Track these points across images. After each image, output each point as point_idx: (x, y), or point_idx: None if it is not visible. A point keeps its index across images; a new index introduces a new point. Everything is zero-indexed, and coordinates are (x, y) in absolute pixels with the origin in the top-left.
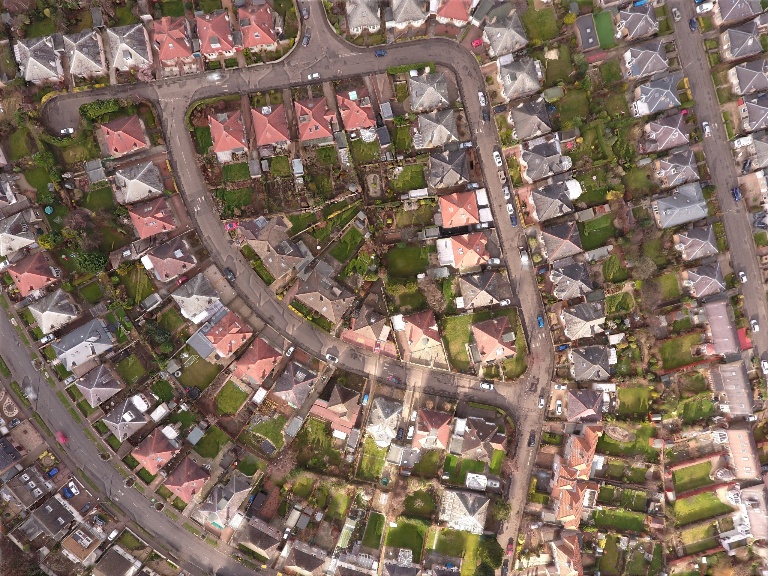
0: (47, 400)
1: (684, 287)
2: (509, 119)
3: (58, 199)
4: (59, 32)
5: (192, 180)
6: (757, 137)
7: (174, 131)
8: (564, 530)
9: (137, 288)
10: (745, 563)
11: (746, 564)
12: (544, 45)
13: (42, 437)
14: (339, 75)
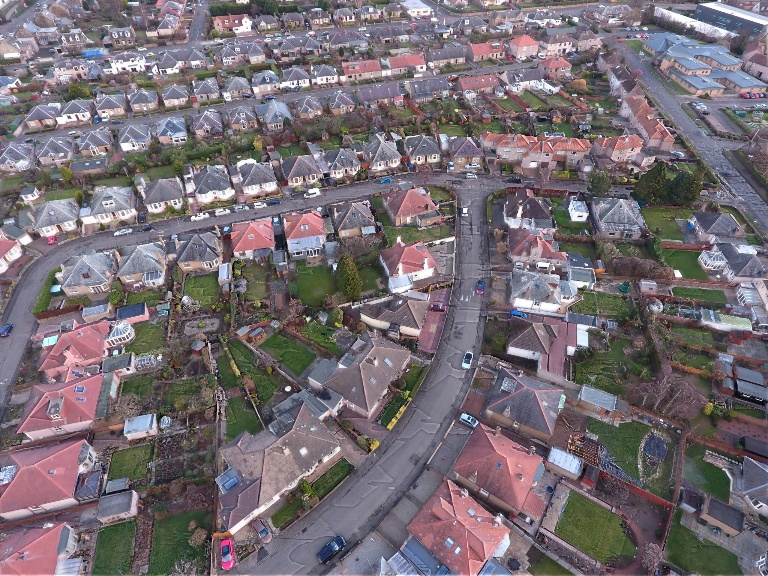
0: None
1: (347, 115)
2: (156, 210)
3: None
4: None
5: None
6: (225, 90)
7: None
8: (595, 155)
9: None
10: (565, 82)
11: (566, 82)
12: (85, 193)
13: None
14: (9, 383)
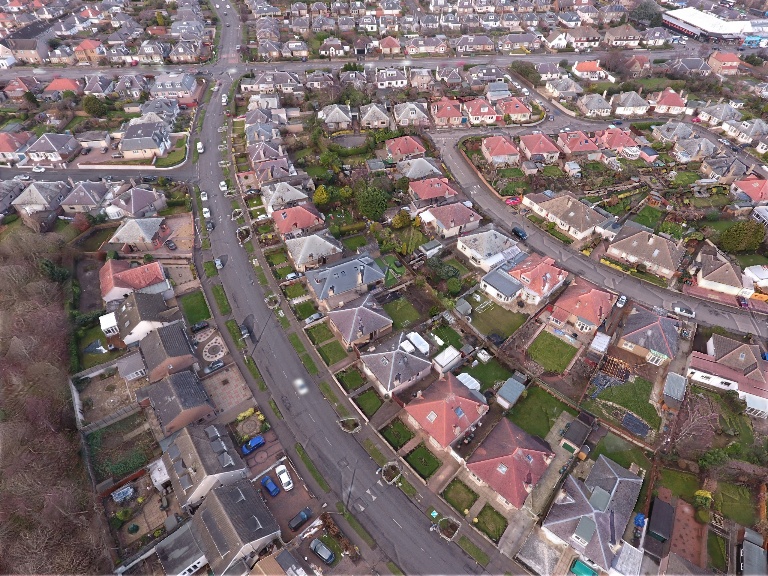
0: (272, 343)
1: None
2: (760, 150)
3: (335, 178)
4: (356, 107)
5: (466, 176)
6: None
7: (446, 152)
8: None
9: (410, 242)
10: None
11: None
12: None
13: (250, 390)
14: None
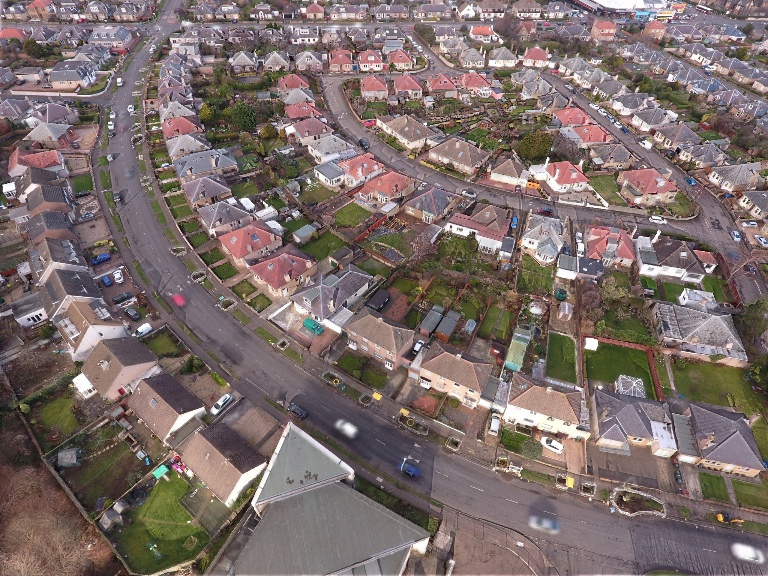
0: (137, 206)
1: None
2: (595, 93)
3: (226, 104)
4: (263, 56)
5: (339, 107)
6: None
7: (330, 90)
8: None
9: (272, 148)
10: None
11: None
12: None
13: (110, 231)
14: None
